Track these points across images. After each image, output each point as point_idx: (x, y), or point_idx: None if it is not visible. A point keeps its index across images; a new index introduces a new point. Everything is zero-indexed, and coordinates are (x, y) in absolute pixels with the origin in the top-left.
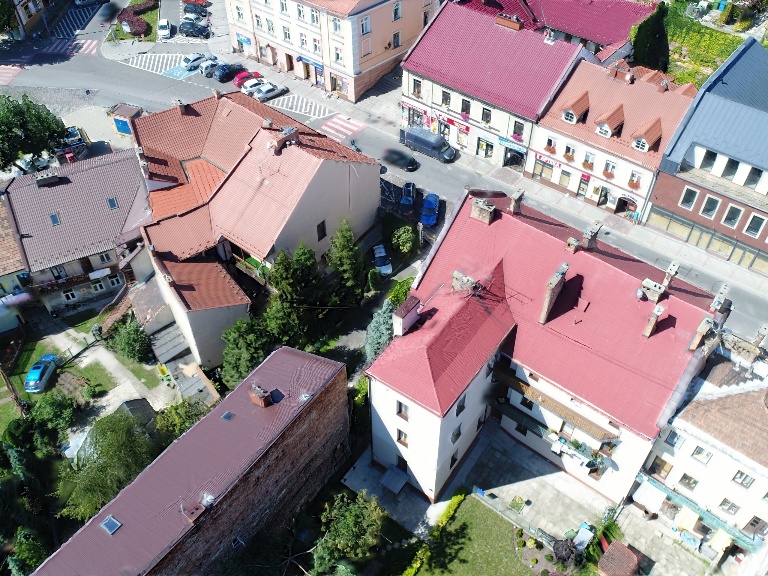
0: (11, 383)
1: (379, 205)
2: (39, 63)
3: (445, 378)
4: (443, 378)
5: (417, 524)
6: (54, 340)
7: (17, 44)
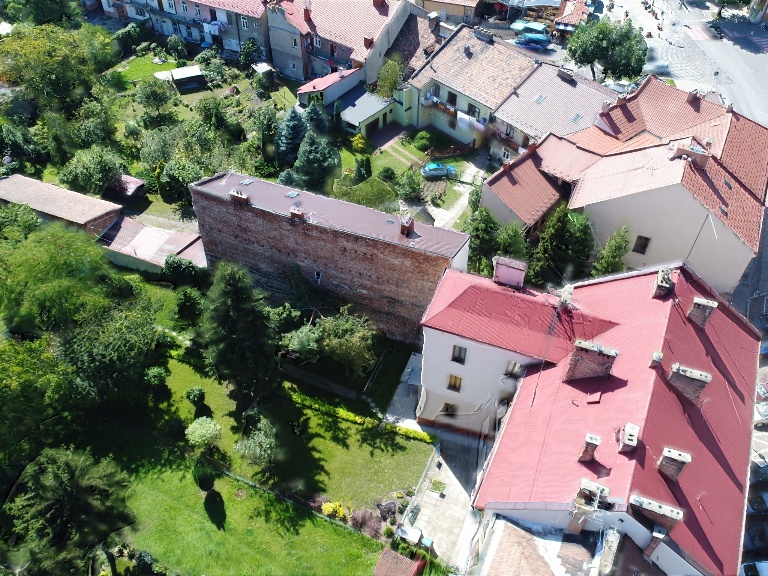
0: (426, 163)
1: (730, 291)
2: (736, 42)
3: (458, 314)
4: (457, 312)
5: (395, 414)
6: (470, 168)
7: (746, 23)
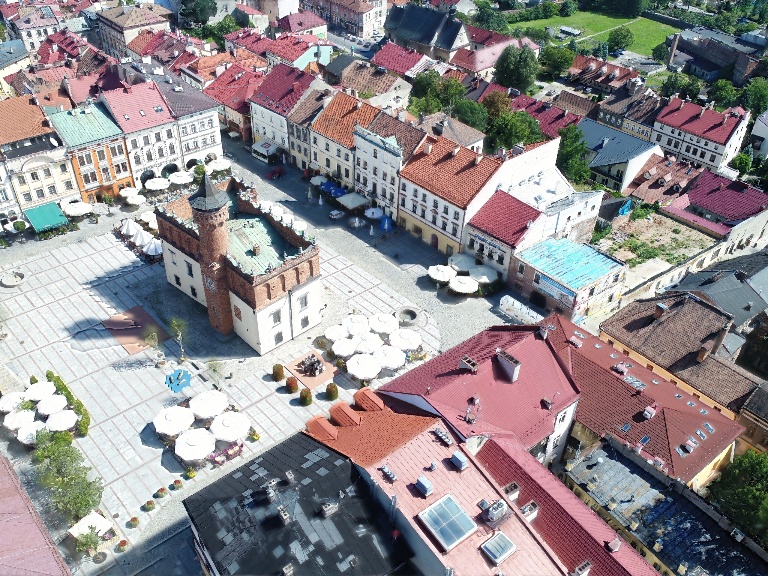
0: None
1: None
2: None
3: None
4: None
5: None
6: None
7: None
